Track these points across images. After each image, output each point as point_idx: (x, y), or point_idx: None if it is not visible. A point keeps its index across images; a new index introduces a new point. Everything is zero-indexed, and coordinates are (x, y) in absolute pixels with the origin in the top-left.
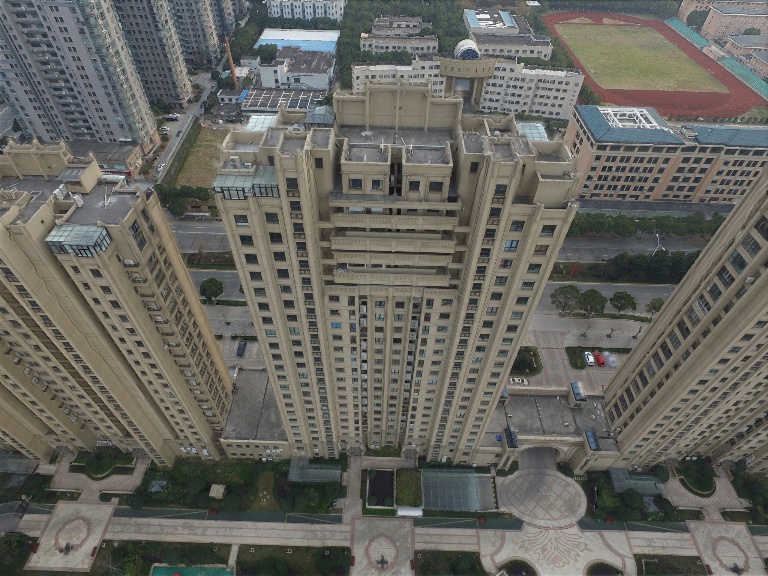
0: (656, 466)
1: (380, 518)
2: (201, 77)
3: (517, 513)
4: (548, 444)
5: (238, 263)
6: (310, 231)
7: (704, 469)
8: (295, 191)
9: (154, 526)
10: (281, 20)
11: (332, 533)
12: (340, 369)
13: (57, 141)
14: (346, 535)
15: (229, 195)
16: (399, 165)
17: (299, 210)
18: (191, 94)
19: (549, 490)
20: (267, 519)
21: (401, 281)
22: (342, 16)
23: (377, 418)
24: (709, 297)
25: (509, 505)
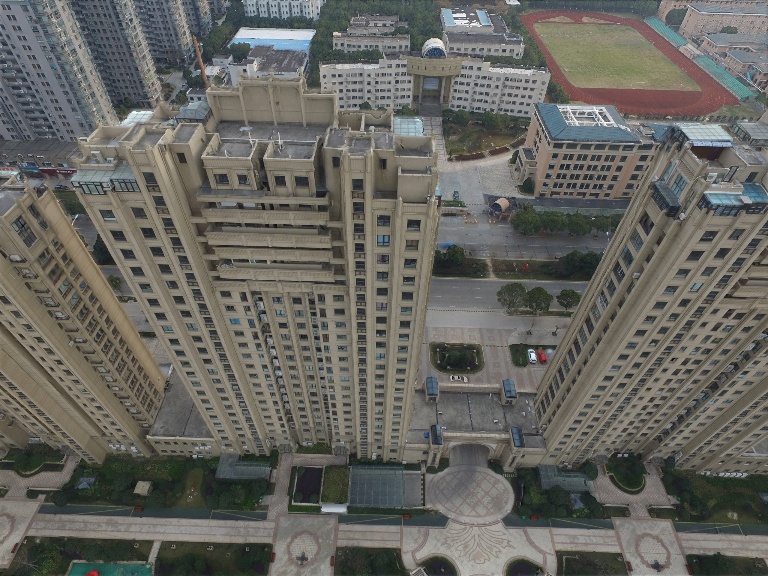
0: (585, 463)
1: (305, 515)
2: (173, 76)
3: (443, 510)
4: (475, 441)
5: (115, 258)
6: (180, 226)
7: (634, 466)
8: (154, 186)
9: (78, 523)
10: (257, 19)
11: (255, 530)
12: (251, 365)
13: (18, 140)
14: (269, 532)
15: (88, 190)
16: (260, 160)
17: (164, 205)
18: (160, 93)
19: (478, 487)
20: (192, 516)
21: (286, 277)
22: (319, 15)
23: (303, 415)
24: (607, 293)
25: (436, 502)
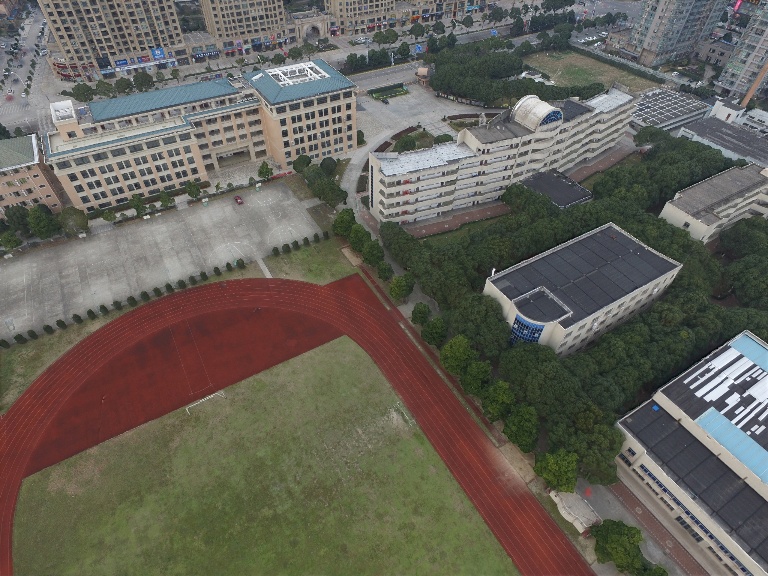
0: None
1: None
2: None
3: None
4: None
5: None
6: None
7: None
8: None
9: None
10: None
11: None
12: None
13: None
14: None
15: None
16: None
17: None
18: None
19: None
20: None
21: None
22: None
23: None
24: None
25: None
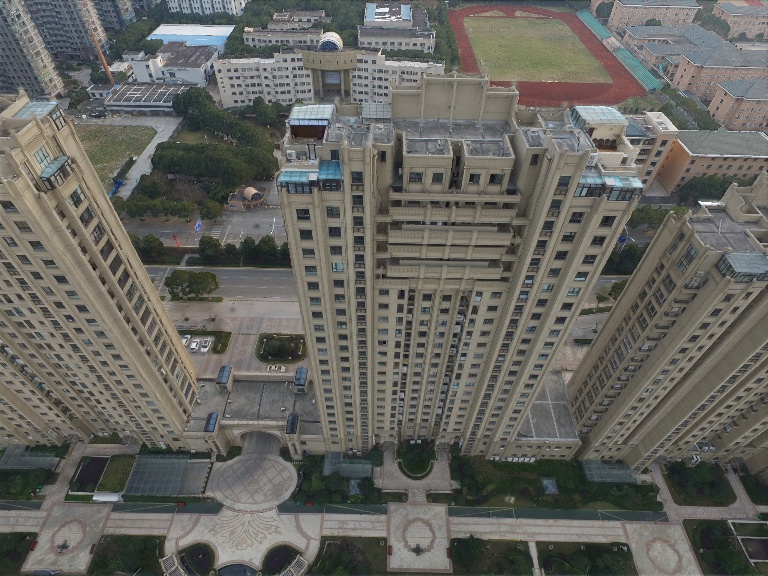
0: (372, 450)
1: (80, 504)
2: (83, 73)
3: (220, 497)
4: (256, 429)
5: None
6: None
7: (422, 452)
8: None
9: None
10: (178, 15)
11: (26, 519)
12: None
13: None
14: (39, 521)
15: None
16: None
17: None
18: (63, 89)
19: (263, 475)
20: None
21: None
22: (243, 11)
23: (80, 404)
24: None
25: (216, 490)
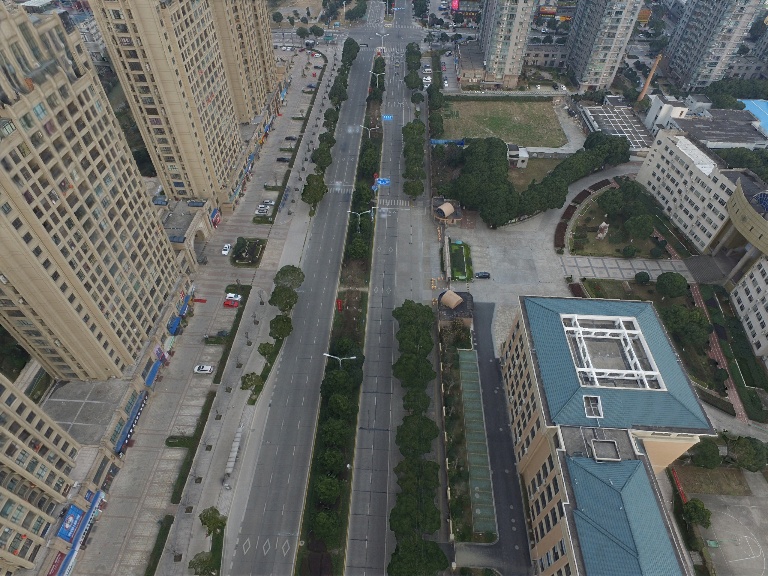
0: None
1: None
2: (652, 90)
3: None
4: None
5: None
6: None
7: None
8: None
9: None
10: None
11: None
12: None
13: None
14: None
15: None
16: None
17: None
18: None
19: None
20: None
21: None
22: None
23: None
24: None
25: None
